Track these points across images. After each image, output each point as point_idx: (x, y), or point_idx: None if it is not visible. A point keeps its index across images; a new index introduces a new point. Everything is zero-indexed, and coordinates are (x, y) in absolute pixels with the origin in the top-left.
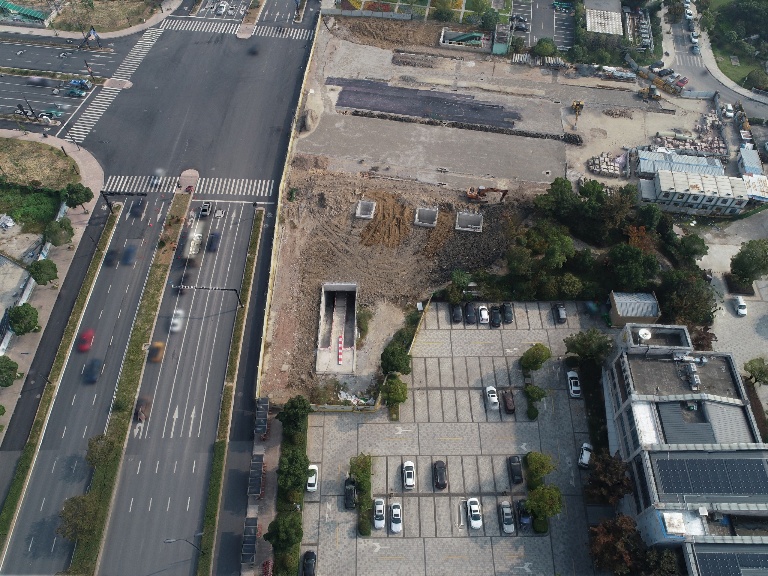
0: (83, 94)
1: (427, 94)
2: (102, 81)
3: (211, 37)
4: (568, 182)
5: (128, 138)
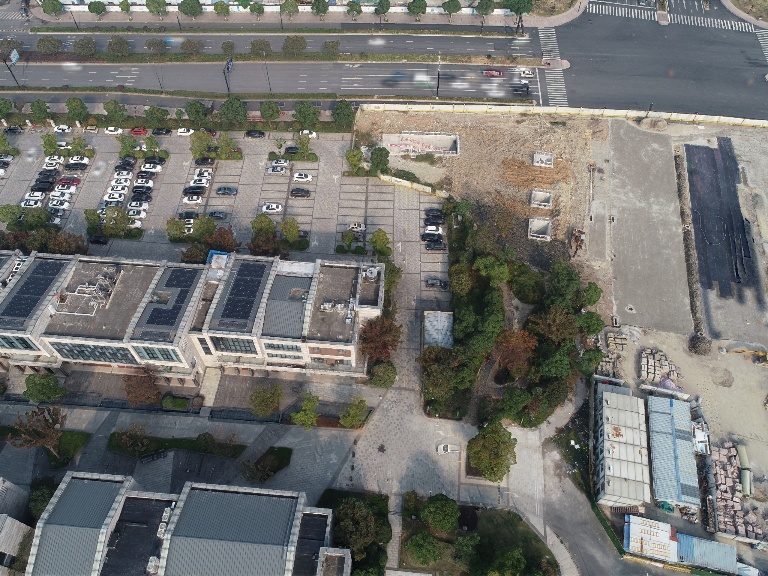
0: (641, 3)
1: (735, 215)
2: (662, 9)
3: (757, 59)
4: (593, 293)
5: (598, 31)
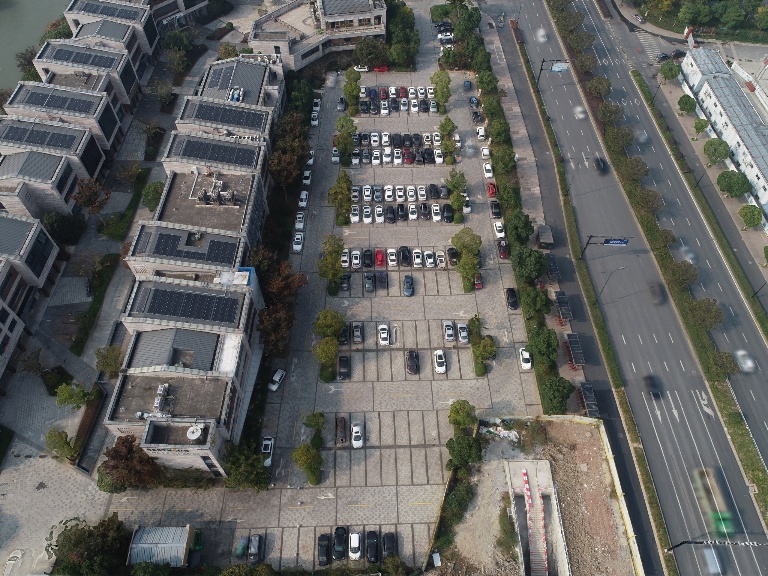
0: None
1: None
2: None
3: None
4: None
5: None
